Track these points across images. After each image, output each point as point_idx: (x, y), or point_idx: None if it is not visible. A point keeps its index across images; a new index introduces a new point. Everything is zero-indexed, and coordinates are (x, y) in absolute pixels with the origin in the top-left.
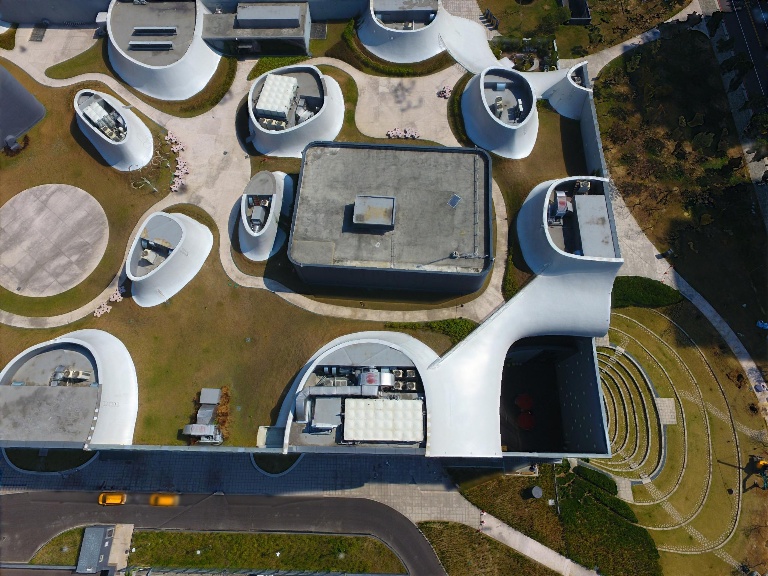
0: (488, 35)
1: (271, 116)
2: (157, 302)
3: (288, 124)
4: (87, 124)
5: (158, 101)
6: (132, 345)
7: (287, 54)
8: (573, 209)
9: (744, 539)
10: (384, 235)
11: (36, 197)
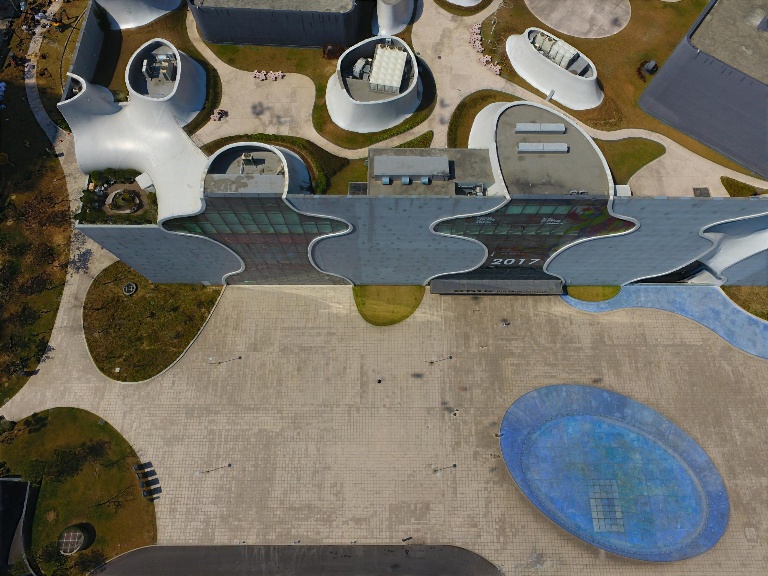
0: (156, 452)
1: None
2: None
3: (376, 53)
4: None
5: None
6: None
7: None
8: None
9: None
10: None
11: (602, 28)
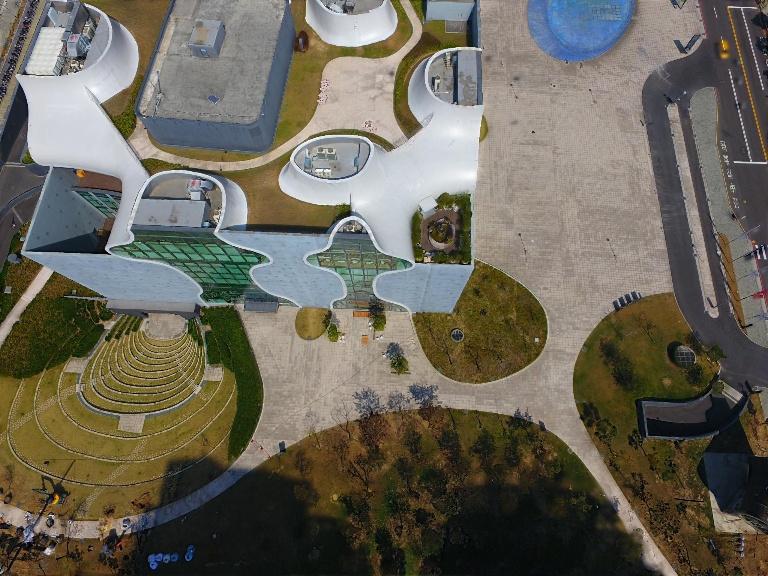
0: (605, 298)
1: None
2: None
3: None
4: None
5: None
6: None
7: None
8: None
9: (7, 463)
10: None
11: None
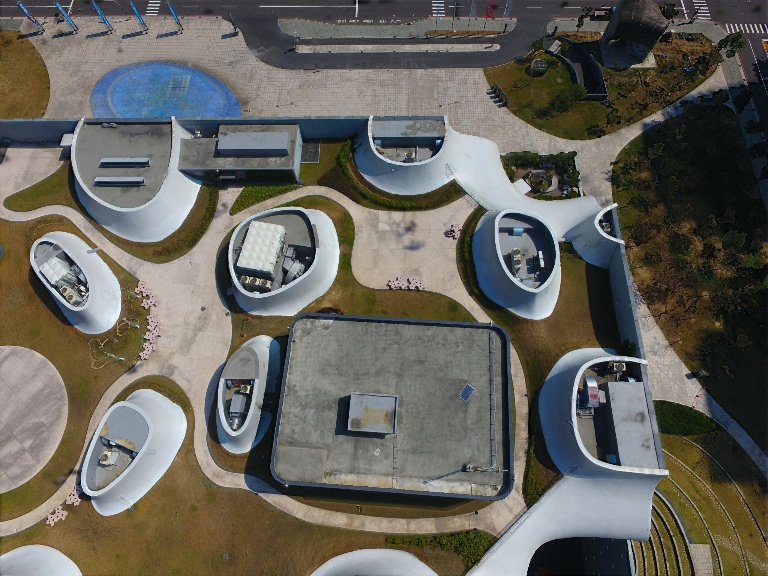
0: (497, 113)
1: (255, 272)
2: (120, 509)
3: (274, 281)
4: (44, 283)
5: (128, 243)
6: (89, 568)
7: (275, 181)
8: (606, 399)
9: None
10: (385, 439)
11: None
